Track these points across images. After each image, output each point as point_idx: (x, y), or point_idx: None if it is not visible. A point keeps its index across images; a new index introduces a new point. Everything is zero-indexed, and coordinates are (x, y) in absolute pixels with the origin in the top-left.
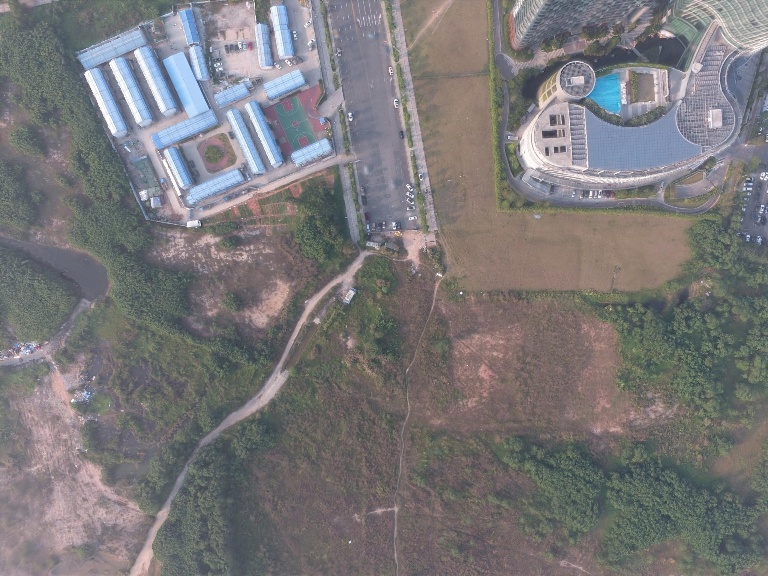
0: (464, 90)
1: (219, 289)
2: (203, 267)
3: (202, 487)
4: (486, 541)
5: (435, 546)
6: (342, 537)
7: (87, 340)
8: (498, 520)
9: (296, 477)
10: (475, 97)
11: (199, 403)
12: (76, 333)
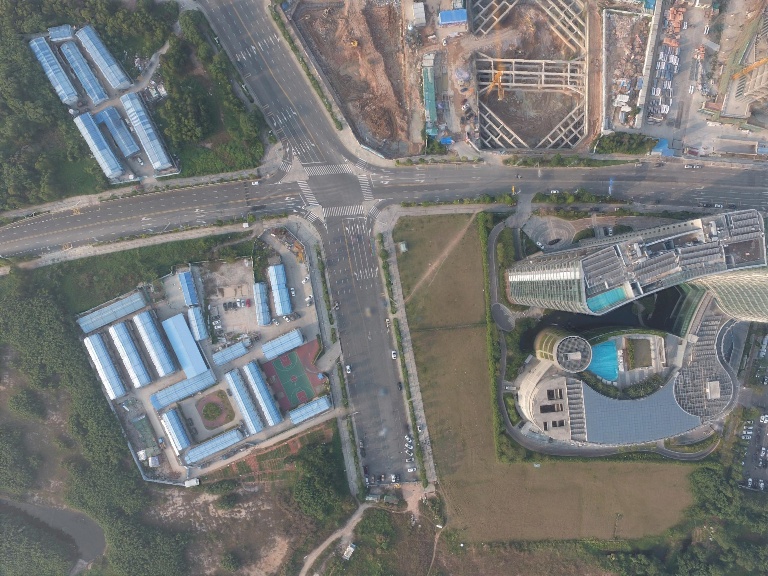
0: (461, 341)
1: (217, 547)
2: (201, 525)
3: None
4: None
5: None
6: None
7: None
8: None
9: None
10: (472, 348)
11: None
12: None
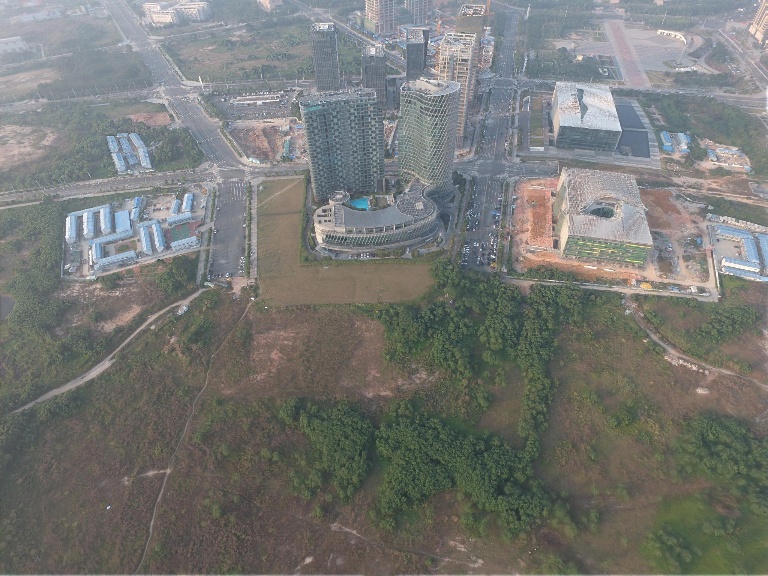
0: (286, 218)
1: (89, 311)
2: (85, 300)
3: None
4: (253, 502)
5: (197, 508)
6: (102, 501)
7: None
8: (269, 478)
9: (83, 441)
10: (292, 221)
11: None
12: None
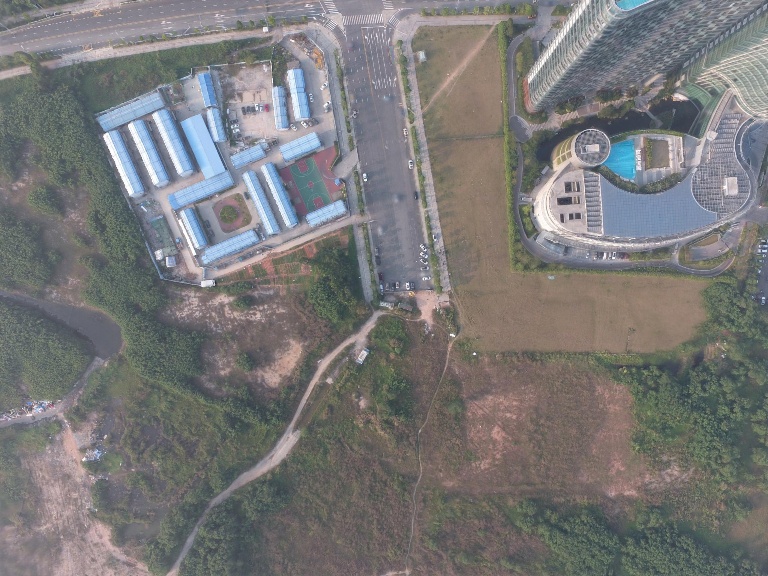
0: (478, 152)
1: (232, 348)
2: (217, 326)
3: (212, 549)
4: None
5: None
6: None
7: (100, 399)
8: None
9: (307, 539)
10: (489, 159)
11: (210, 463)
12: (89, 392)
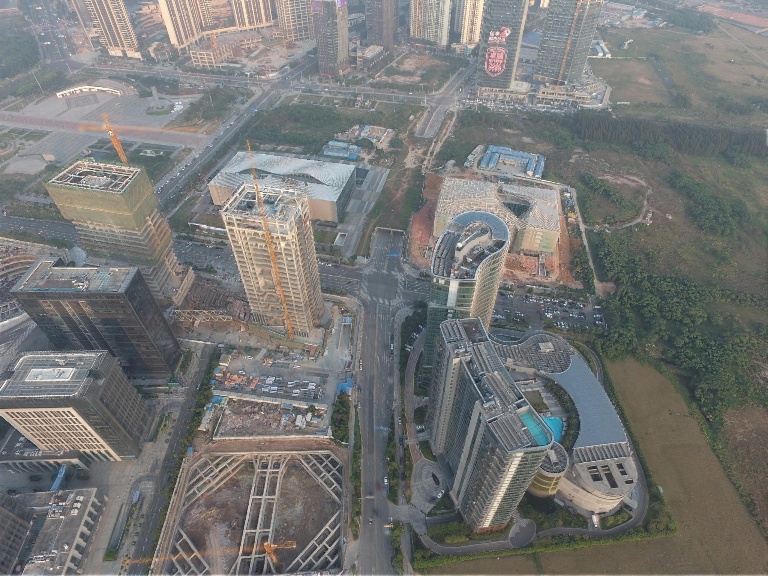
0: None
1: None
2: None
3: None
4: None
5: None
6: None
7: None
8: None
9: None
10: (565, 570)
11: None
12: None
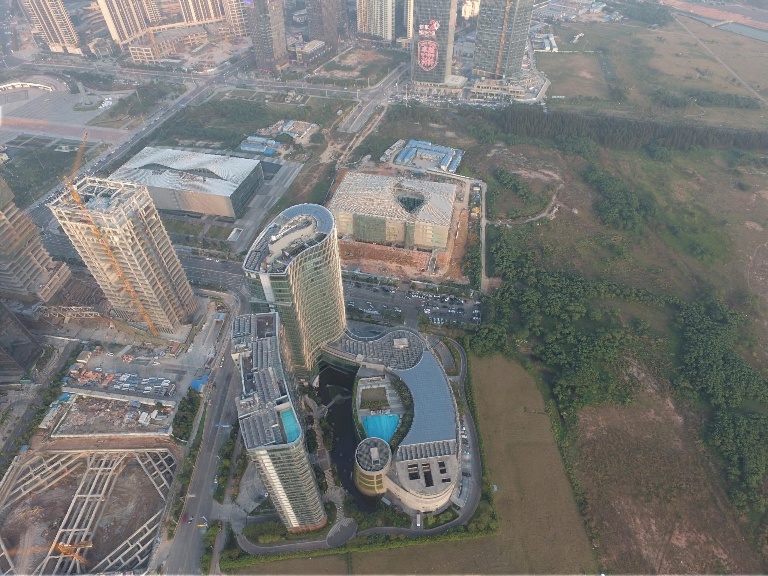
0: None
1: None
2: None
3: None
4: None
5: None
6: None
7: None
8: None
9: None
10: (376, 570)
11: None
12: None
